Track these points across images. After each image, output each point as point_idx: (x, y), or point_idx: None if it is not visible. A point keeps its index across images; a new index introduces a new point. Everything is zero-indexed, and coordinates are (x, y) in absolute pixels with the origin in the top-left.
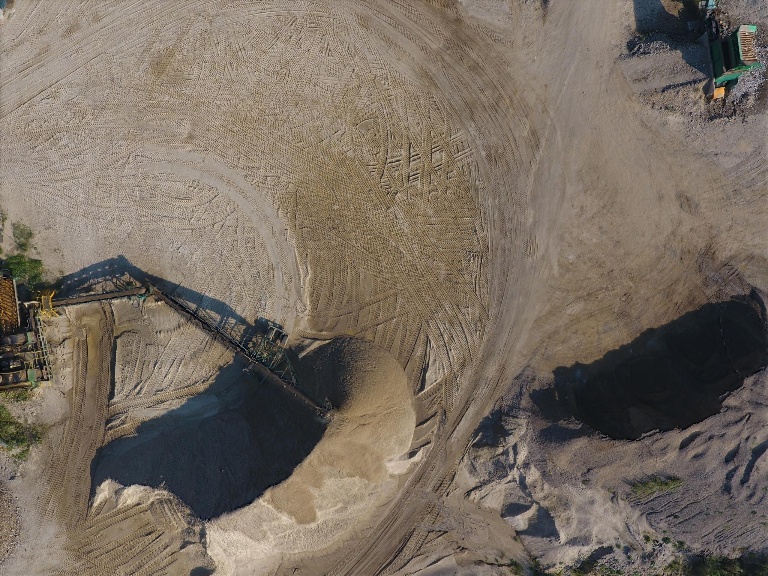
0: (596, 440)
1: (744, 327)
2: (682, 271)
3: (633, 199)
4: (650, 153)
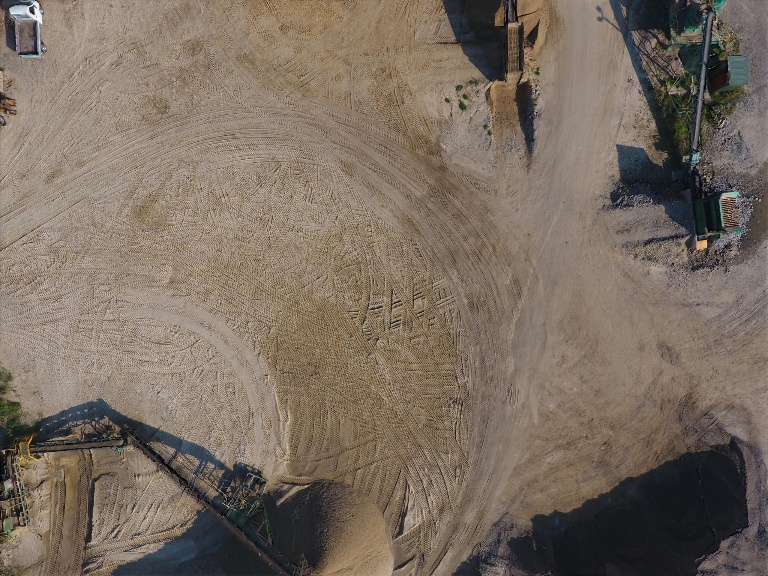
0: None
1: (722, 481)
2: (662, 420)
3: (614, 349)
4: (632, 303)
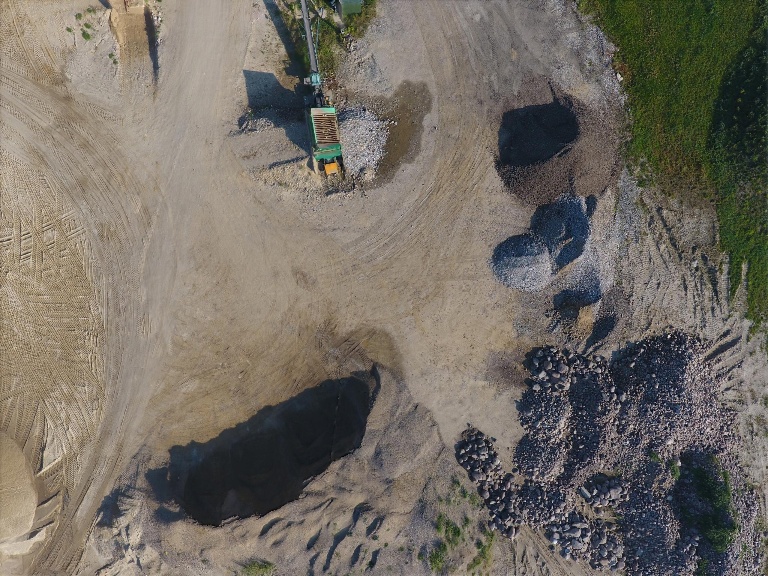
0: (190, 524)
1: (355, 405)
2: (301, 347)
3: (247, 276)
4: (264, 229)
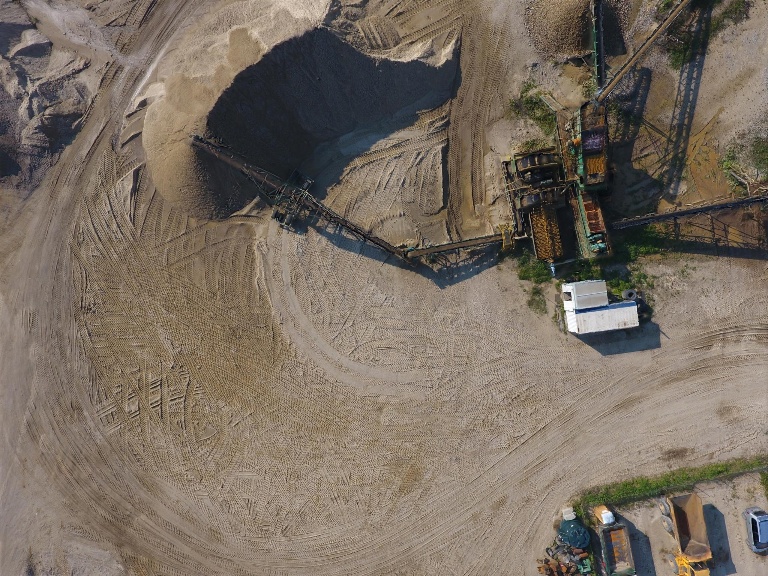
0: None
1: None
2: None
3: None
4: None
